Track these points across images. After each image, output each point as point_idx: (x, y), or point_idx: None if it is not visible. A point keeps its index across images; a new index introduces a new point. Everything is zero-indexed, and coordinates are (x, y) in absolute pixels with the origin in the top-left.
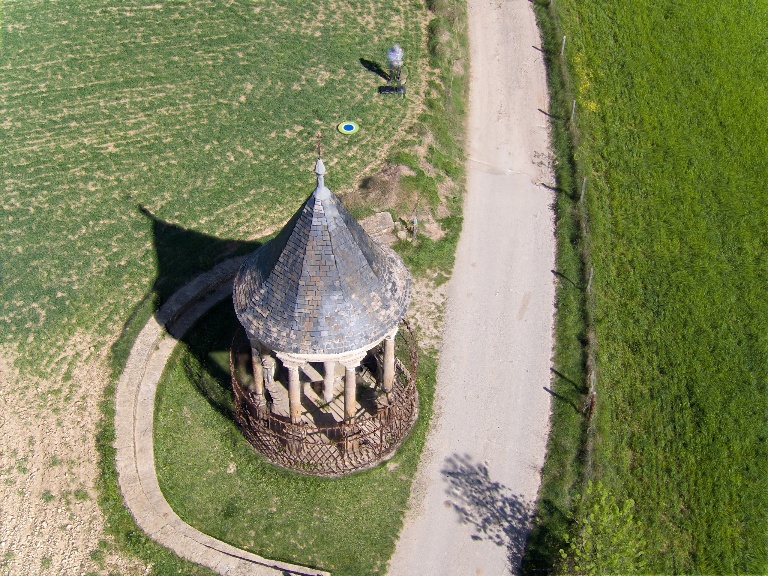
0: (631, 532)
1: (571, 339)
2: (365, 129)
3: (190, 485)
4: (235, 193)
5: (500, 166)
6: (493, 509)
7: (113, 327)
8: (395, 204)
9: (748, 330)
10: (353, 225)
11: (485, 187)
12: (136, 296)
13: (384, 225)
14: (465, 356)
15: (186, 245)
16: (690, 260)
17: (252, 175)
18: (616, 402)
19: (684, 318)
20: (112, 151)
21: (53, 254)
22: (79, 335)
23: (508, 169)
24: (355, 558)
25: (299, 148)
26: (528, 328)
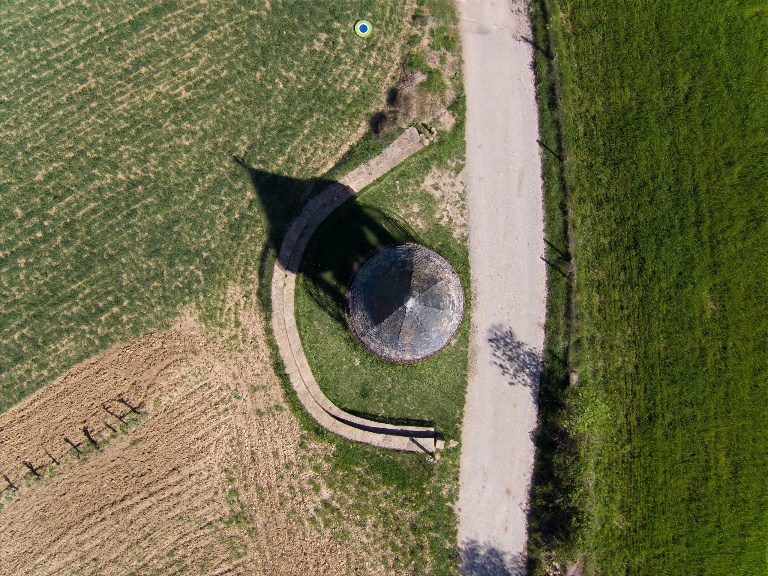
0: (600, 357)
1: (556, 211)
2: (377, 27)
3: (336, 380)
4: (296, 129)
5: (486, 23)
6: (518, 361)
7: (252, 277)
8: (416, 111)
9: (676, 176)
10: (427, 297)
11: (478, 53)
12: (257, 247)
13: (413, 141)
14: (486, 240)
15: (277, 192)
16: (637, 111)
17: (302, 104)
18: (588, 258)
19: (632, 173)
20: (186, 96)
21: (186, 218)
22: (232, 288)
23: (493, 25)
24: (444, 411)
25: (330, 63)
26: (525, 204)
